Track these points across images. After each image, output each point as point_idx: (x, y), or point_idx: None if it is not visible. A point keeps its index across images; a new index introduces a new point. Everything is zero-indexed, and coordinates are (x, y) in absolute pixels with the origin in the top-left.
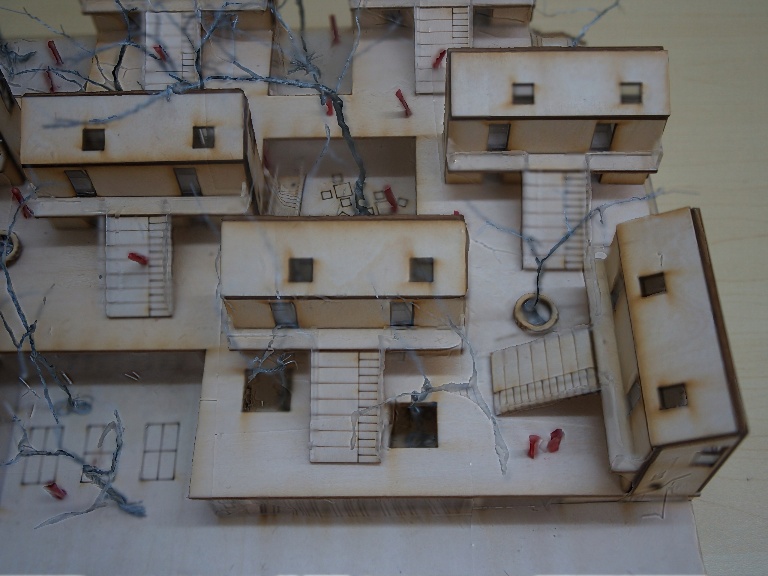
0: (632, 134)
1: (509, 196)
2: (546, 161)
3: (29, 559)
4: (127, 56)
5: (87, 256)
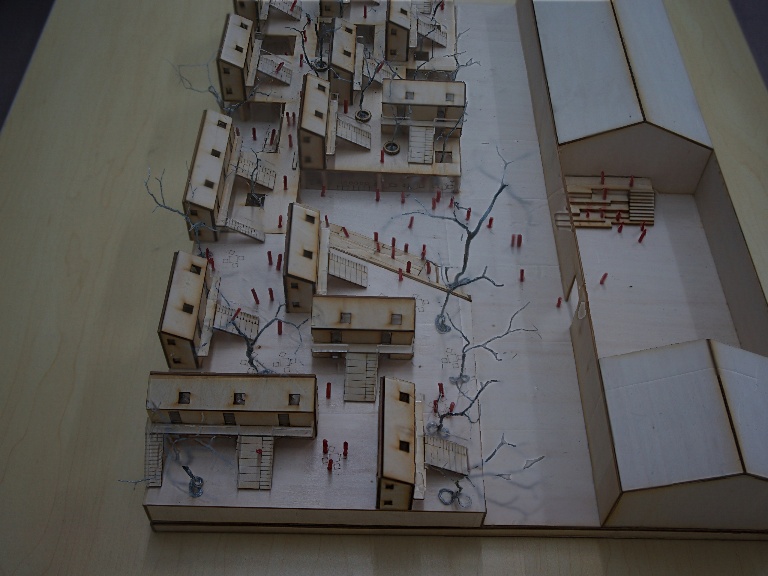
0: None
1: (350, 4)
2: None
3: None
4: (264, 92)
5: (366, 97)
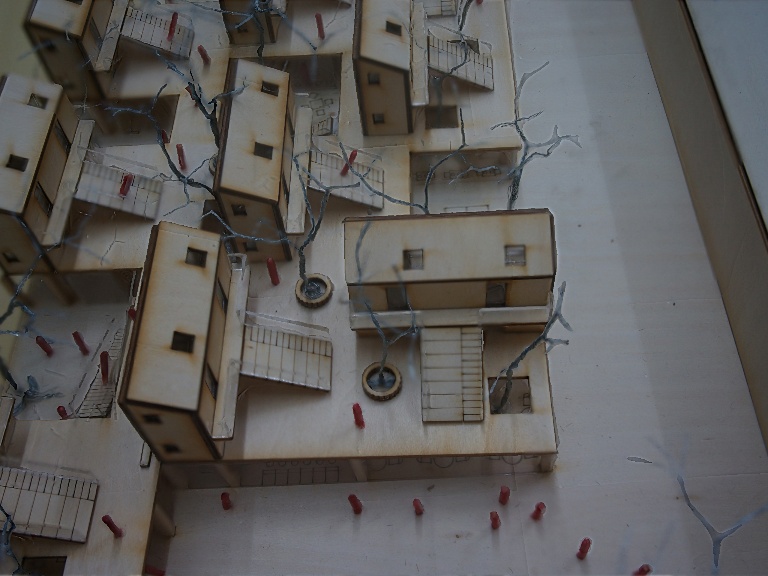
0: None
1: (292, 11)
2: None
3: (555, 279)
4: (97, 244)
5: (323, 234)
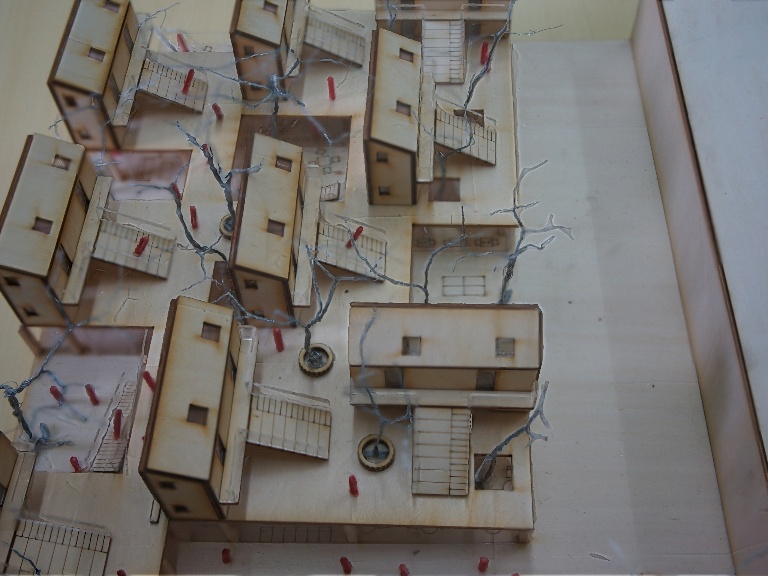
0: None
1: (304, 68)
2: None
3: None
4: (111, 300)
5: None
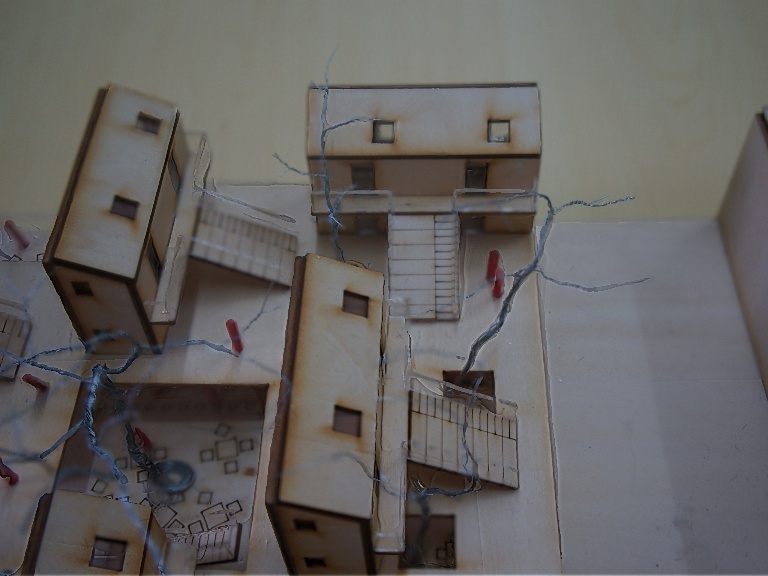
0: (179, 148)
1: (194, 293)
2: (181, 233)
3: None
4: None
5: None
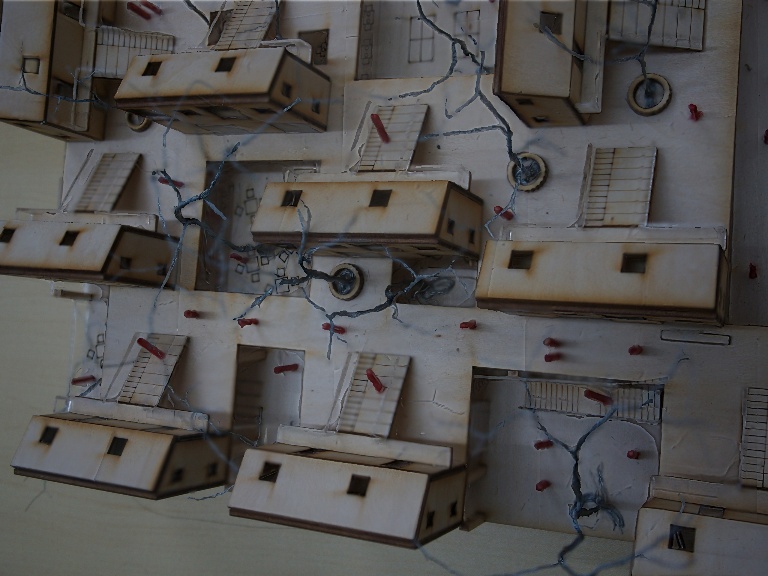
0: None
1: None
2: (93, 221)
3: None
4: (434, 421)
5: (452, 169)
